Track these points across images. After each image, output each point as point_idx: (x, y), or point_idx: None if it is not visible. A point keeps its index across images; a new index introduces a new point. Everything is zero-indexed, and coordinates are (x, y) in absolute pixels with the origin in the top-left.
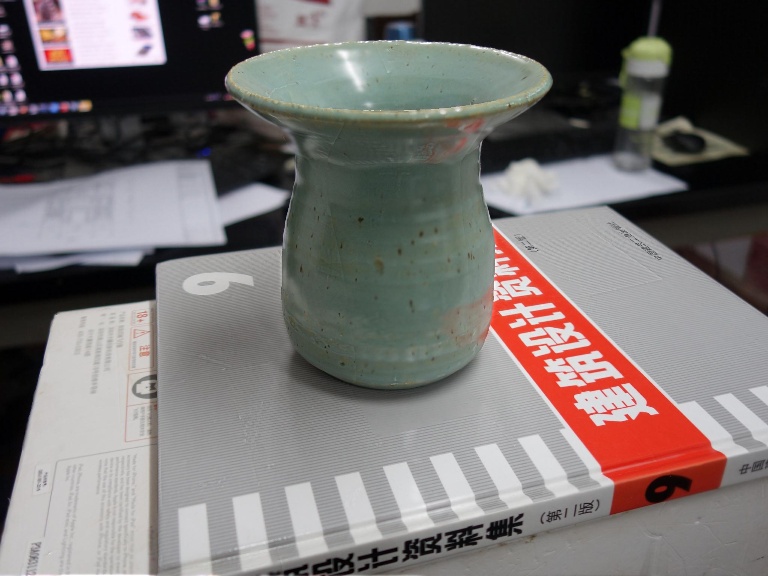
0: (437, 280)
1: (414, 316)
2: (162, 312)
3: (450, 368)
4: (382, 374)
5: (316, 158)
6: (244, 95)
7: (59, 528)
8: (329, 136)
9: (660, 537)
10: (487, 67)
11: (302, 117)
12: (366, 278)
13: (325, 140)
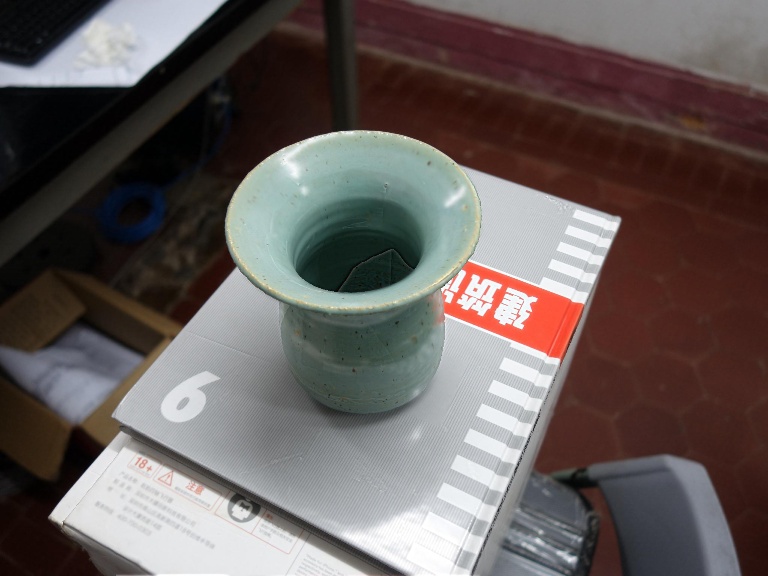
0: (439, 321)
1: (434, 349)
2: (191, 453)
3: None
4: (420, 390)
5: None
6: (330, 311)
7: None
8: None
9: (564, 359)
10: (376, 152)
11: None
12: (409, 351)
13: None
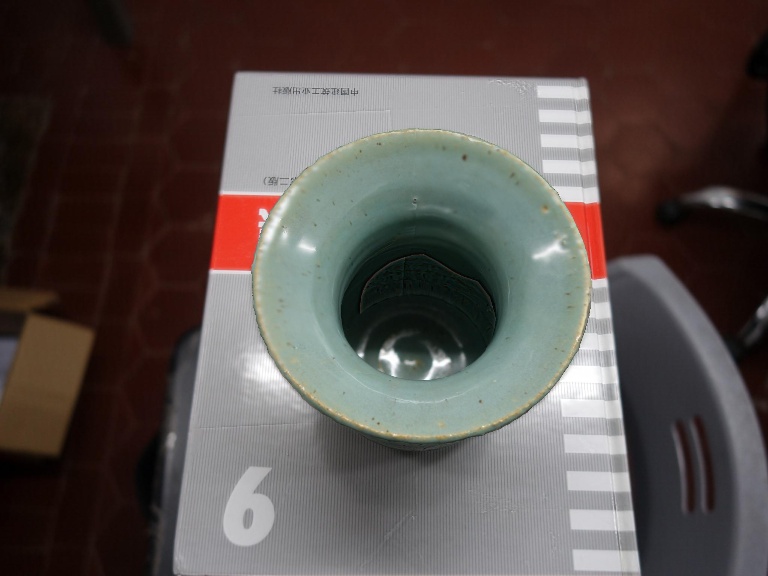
0: None
1: None
2: (295, 572)
3: None
4: None
5: None
6: (483, 432)
7: None
8: None
9: None
10: (387, 163)
11: None
12: None
13: None
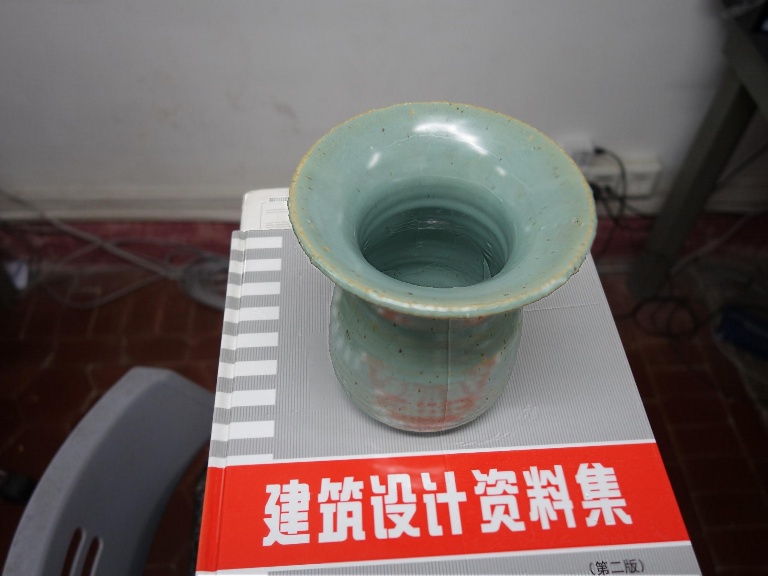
0: None
1: None
2: None
3: None
4: None
5: None
6: None
7: None
8: None
9: None
10: (492, 289)
11: None
12: None
13: None
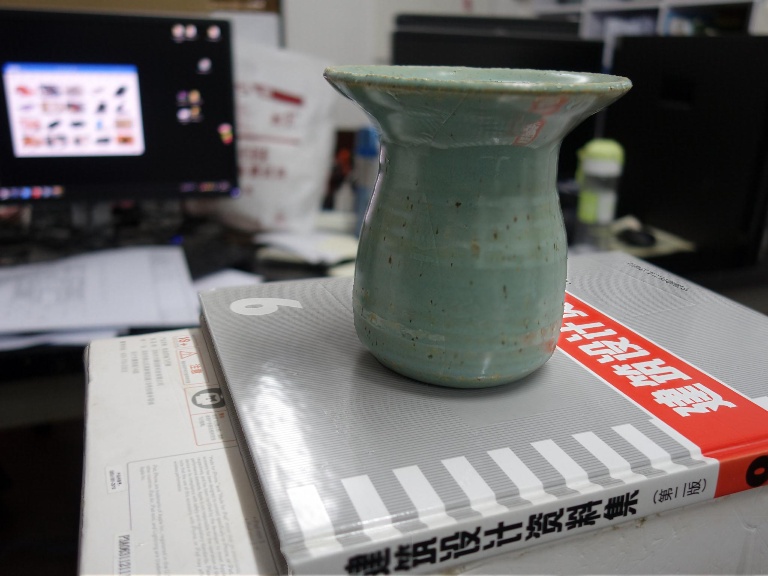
0: (529, 266)
1: (507, 302)
2: (216, 328)
3: (533, 363)
4: (471, 366)
5: (418, 144)
6: (358, 77)
7: (146, 522)
8: (444, 112)
9: (755, 529)
10: None
11: (425, 89)
12: (462, 262)
13: (437, 118)
